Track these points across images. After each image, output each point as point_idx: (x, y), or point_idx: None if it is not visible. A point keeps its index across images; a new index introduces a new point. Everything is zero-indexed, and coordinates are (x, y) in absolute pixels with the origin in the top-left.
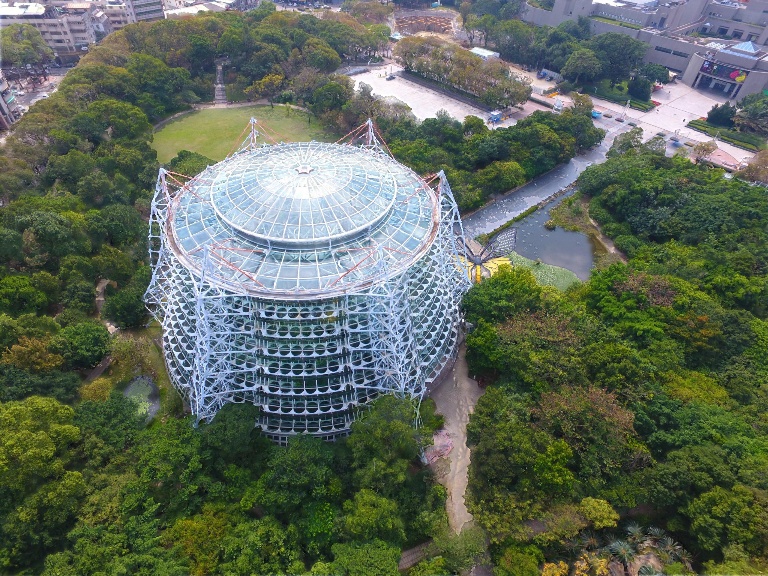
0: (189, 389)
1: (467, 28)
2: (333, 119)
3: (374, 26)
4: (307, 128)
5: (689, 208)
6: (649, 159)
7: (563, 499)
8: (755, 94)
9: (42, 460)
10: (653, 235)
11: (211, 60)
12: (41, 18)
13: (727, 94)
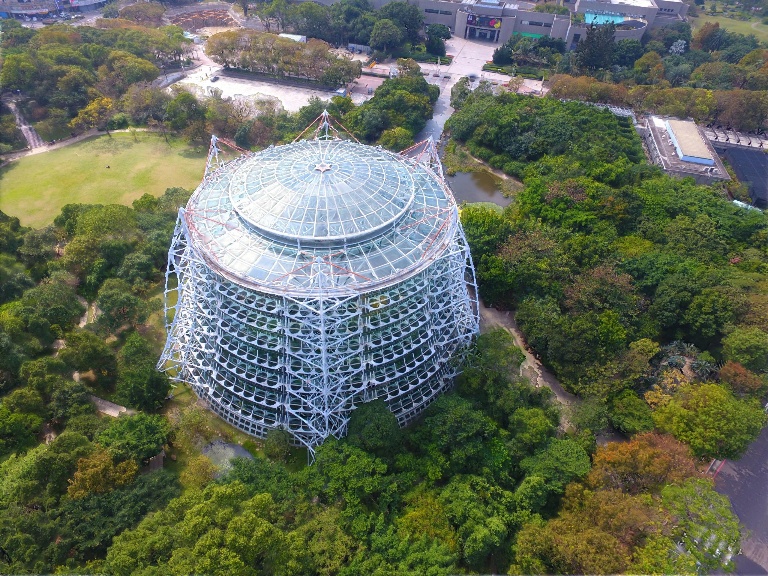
0: (282, 426)
1: (260, 16)
2: (200, 131)
3: (162, 28)
4: (170, 148)
5: (546, 128)
6: (495, 99)
7: (622, 351)
8: (515, 35)
9: (267, 536)
10: (528, 156)
11: None
12: None
13: (491, 39)
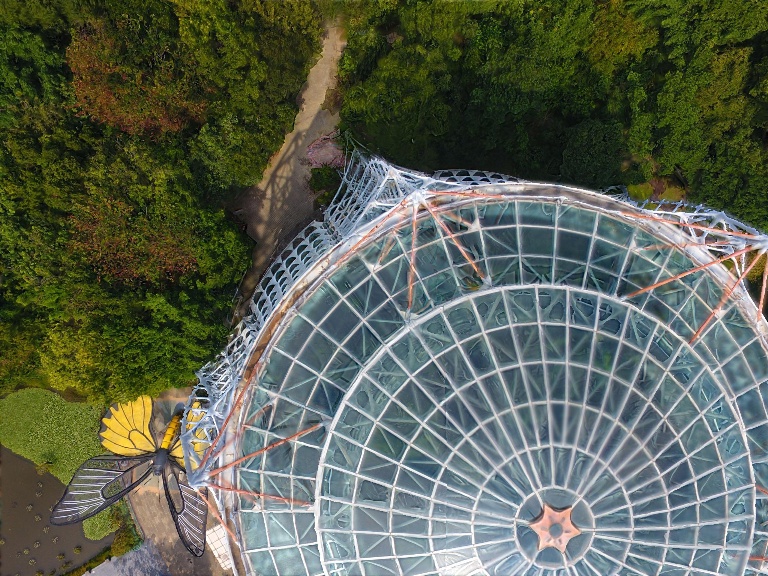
0: None
1: None
2: None
3: None
4: None
5: None
6: None
7: None
8: None
9: None
10: None
11: None
12: None
13: None
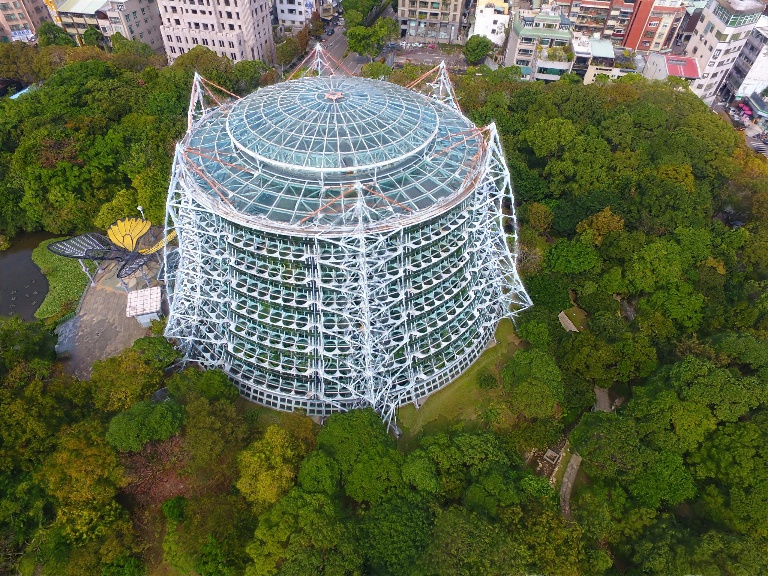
0: None
1: None
2: None
3: None
4: None
5: None
6: None
7: None
8: None
9: None
10: None
11: None
12: None
13: None
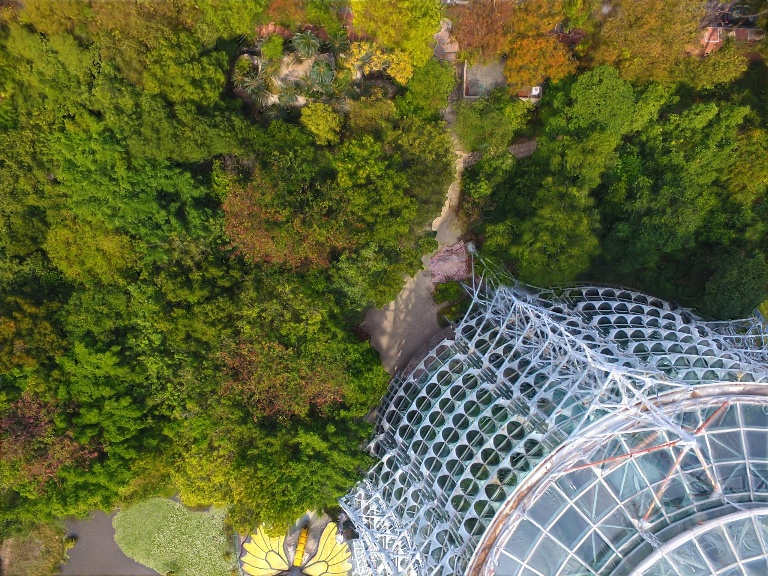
0: None
1: None
2: None
3: None
4: None
5: None
6: None
7: None
8: None
9: None
10: None
11: None
12: None
13: None
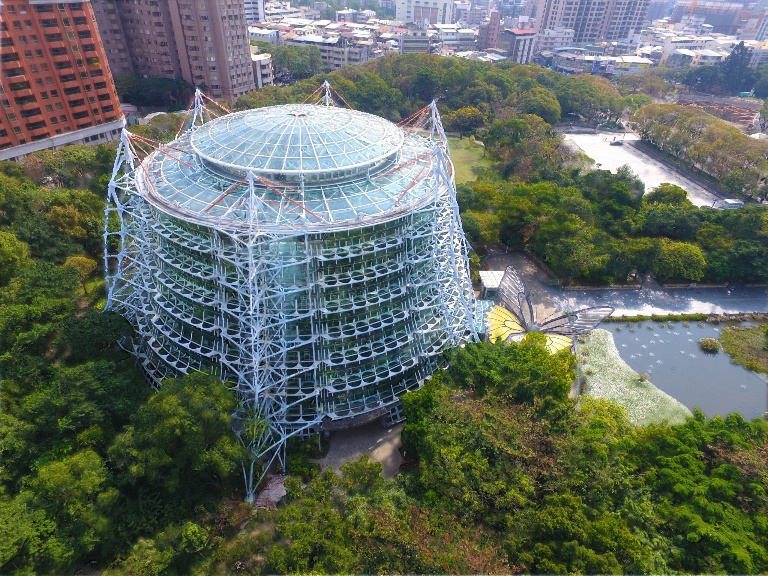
0: None
1: (762, 113)
2: None
3: (633, 95)
4: (476, 161)
5: None
6: None
7: None
8: None
9: None
10: None
11: (432, 91)
12: (332, 46)
13: None
